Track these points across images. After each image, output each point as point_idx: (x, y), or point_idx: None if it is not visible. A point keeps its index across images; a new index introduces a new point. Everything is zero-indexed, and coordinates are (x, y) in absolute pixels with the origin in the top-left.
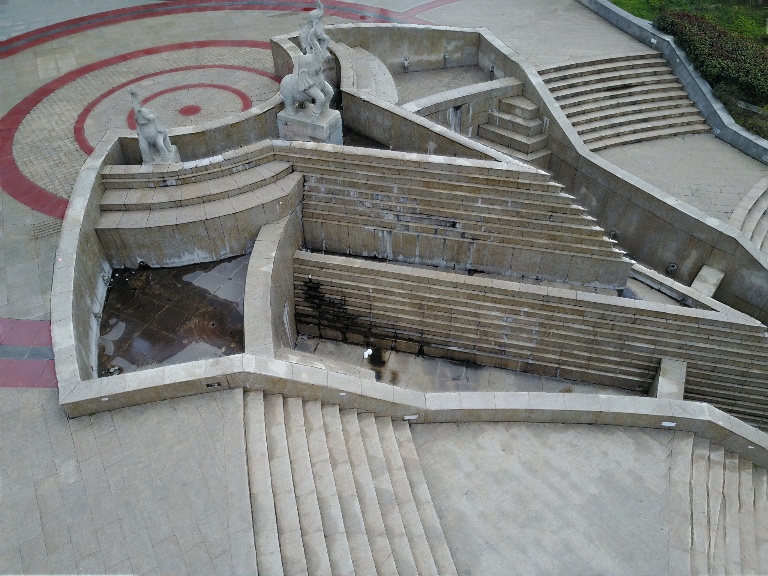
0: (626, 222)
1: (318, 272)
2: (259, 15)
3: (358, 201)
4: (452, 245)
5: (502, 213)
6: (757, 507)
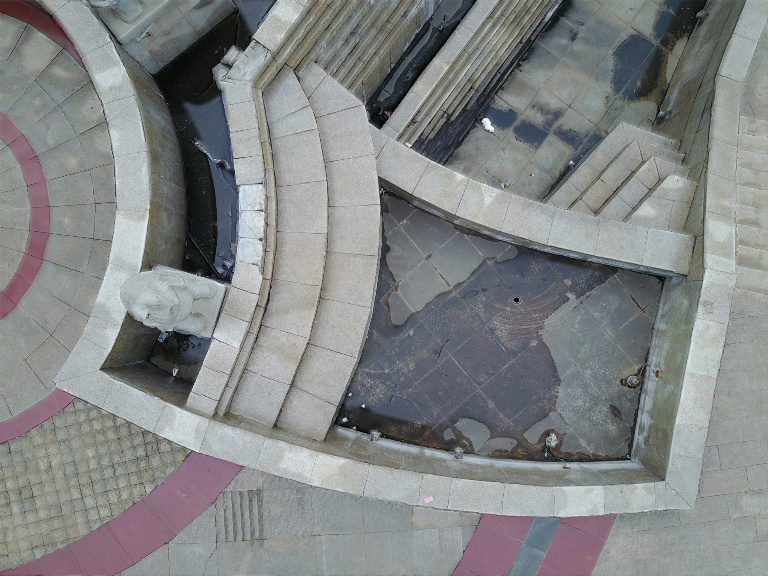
0: None
1: None
2: None
3: None
4: None
5: None
6: None
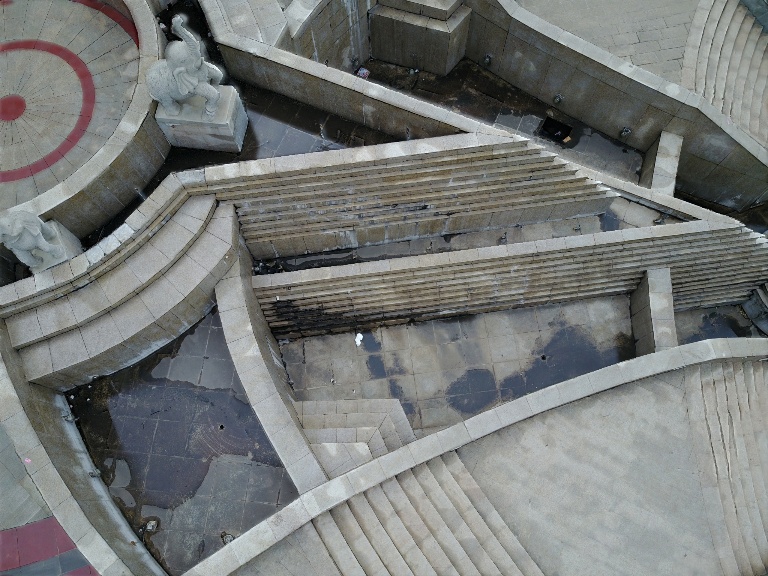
0: (572, 89)
1: (286, 293)
2: None
3: (308, 212)
4: (425, 224)
5: (477, 185)
6: (751, 405)
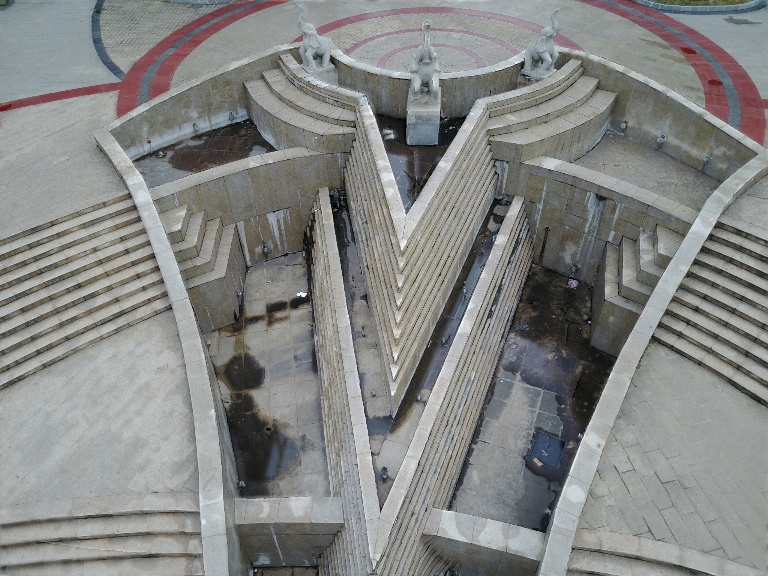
0: None
1: None
2: (637, 34)
3: None
4: None
5: None
6: None
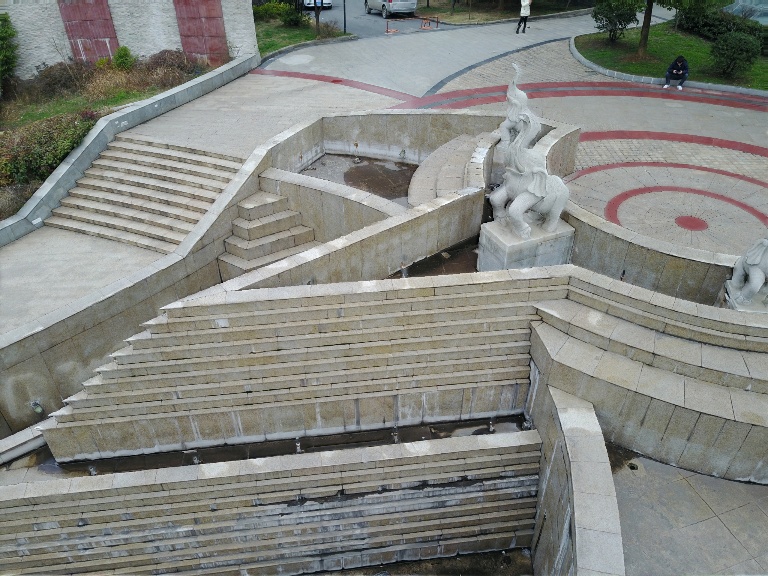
0: None
1: None
2: None
3: None
4: None
5: None
6: None
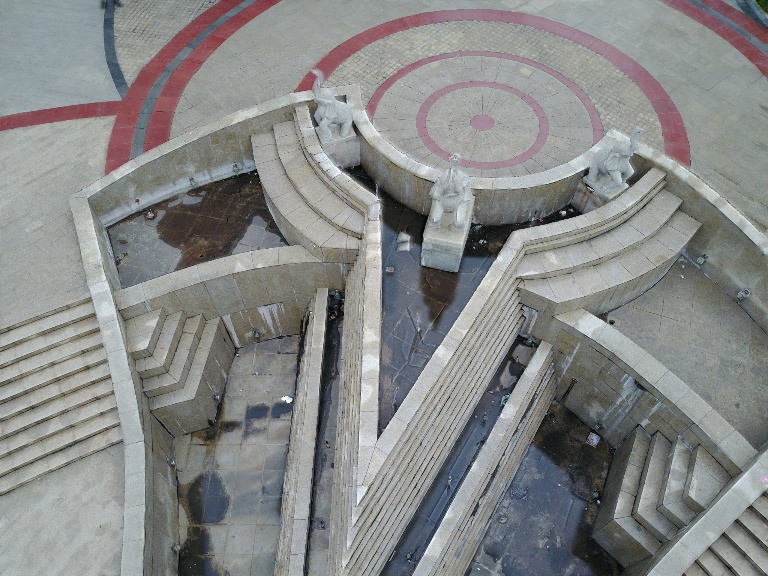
0: None
1: None
2: (760, 97)
3: None
4: None
5: None
6: None
